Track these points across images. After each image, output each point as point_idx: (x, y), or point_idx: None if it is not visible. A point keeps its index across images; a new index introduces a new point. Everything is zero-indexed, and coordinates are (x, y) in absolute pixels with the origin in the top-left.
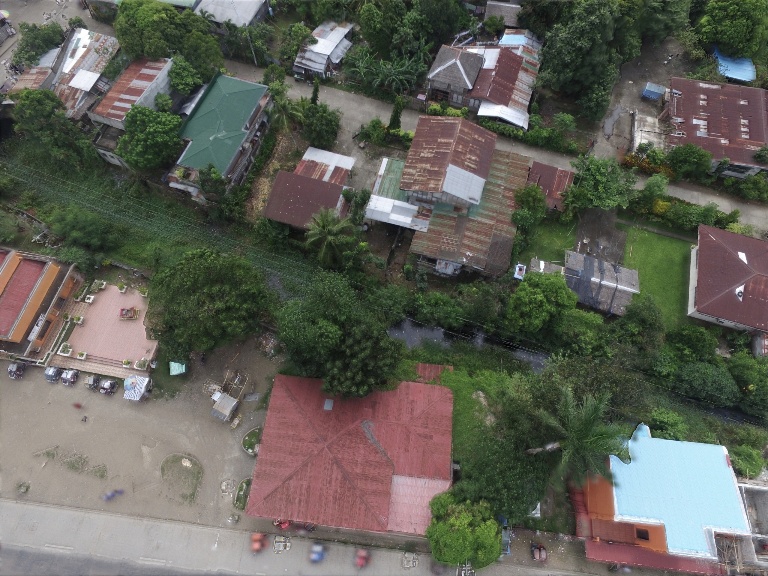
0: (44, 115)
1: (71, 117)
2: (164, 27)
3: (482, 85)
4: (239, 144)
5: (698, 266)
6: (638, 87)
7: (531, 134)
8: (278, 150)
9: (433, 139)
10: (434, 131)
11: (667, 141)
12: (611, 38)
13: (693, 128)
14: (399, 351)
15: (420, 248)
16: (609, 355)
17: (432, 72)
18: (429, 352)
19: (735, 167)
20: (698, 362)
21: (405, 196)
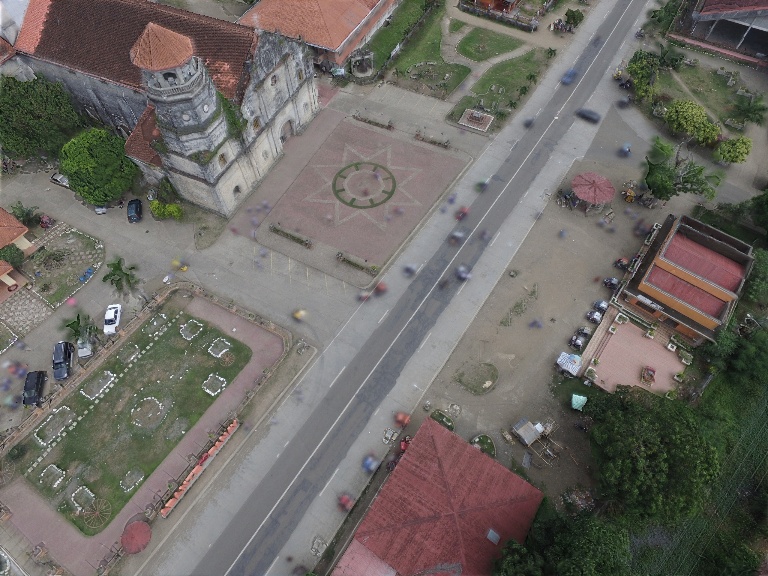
0: None
1: None
2: None
3: None
4: None
5: None
6: None
7: None
8: None
9: None
10: None
11: None
12: None
13: None
14: None
15: None
16: None
17: None
18: None
19: None
20: None
21: None
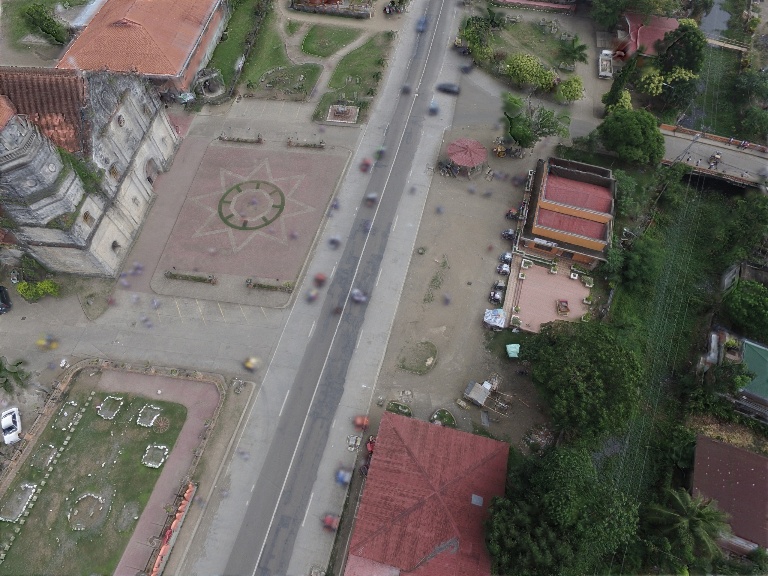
0: (766, 219)
1: None
2: None
3: None
4: None
5: None
6: None
7: None
8: None
9: None
10: None
11: None
12: None
13: None
14: None
15: None
16: None
17: None
18: None
19: None
20: None
21: None
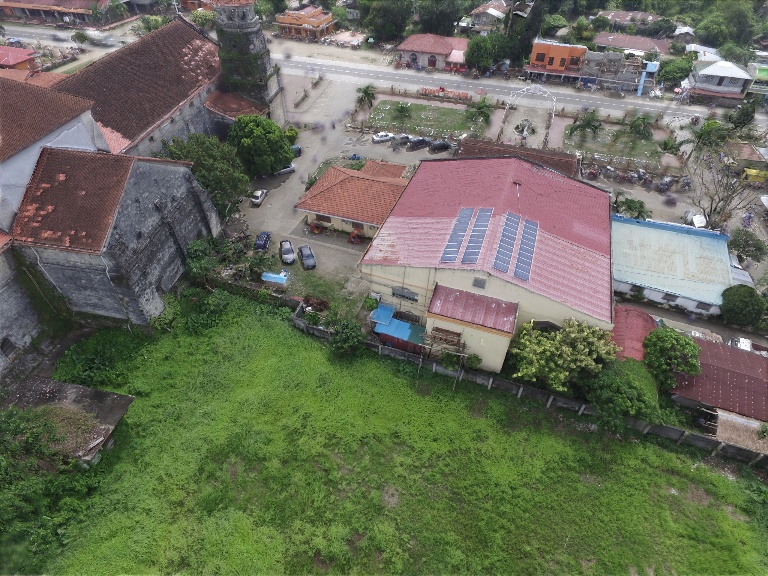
0: None
1: (336, 5)
2: None
3: None
4: None
5: None
6: None
7: None
8: None
9: None
10: (486, 5)
11: None
12: None
13: None
14: None
15: (474, 29)
16: None
17: None
18: None
19: None
20: None
21: None
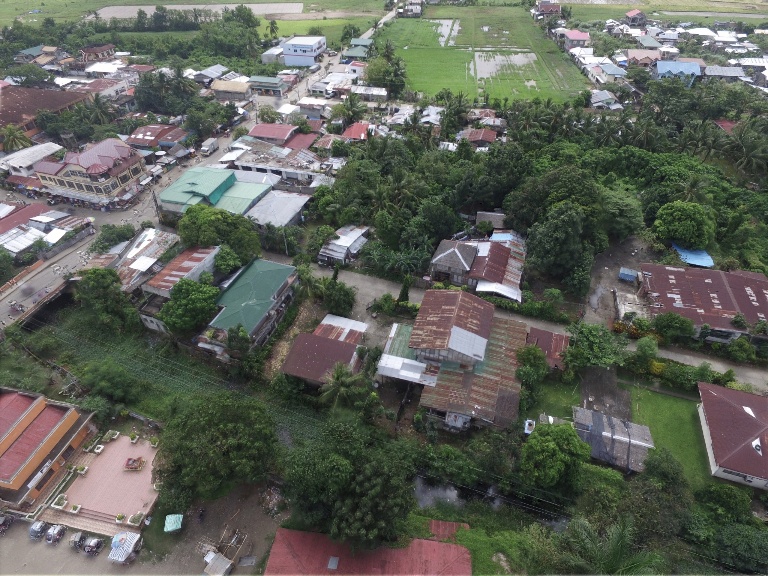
0: (104, 286)
1: (124, 290)
2: (218, 224)
3: (478, 268)
4: (266, 310)
5: (707, 421)
6: (613, 272)
7: (525, 306)
8: (299, 319)
9: (438, 306)
10: (438, 300)
11: (649, 313)
12: (580, 231)
13: (669, 300)
14: (410, 494)
15: (429, 401)
16: (637, 515)
17: (435, 258)
18: (442, 512)
19: (716, 331)
20: (736, 524)
21: (414, 355)
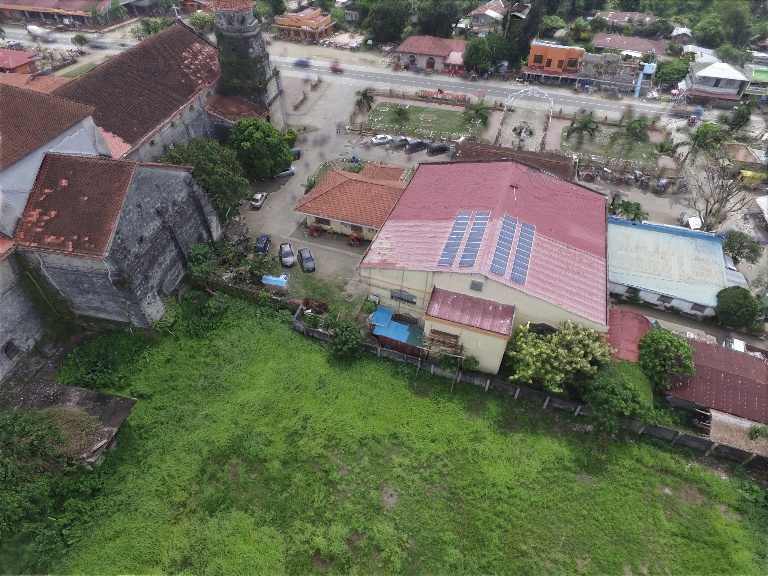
0: None
1: (335, 7)
2: None
3: None
4: None
5: None
6: None
7: None
8: None
9: (483, 7)
10: None
11: None
12: None
13: None
14: None
15: None
16: None
17: (487, 3)
18: None
19: None
20: None
21: None
